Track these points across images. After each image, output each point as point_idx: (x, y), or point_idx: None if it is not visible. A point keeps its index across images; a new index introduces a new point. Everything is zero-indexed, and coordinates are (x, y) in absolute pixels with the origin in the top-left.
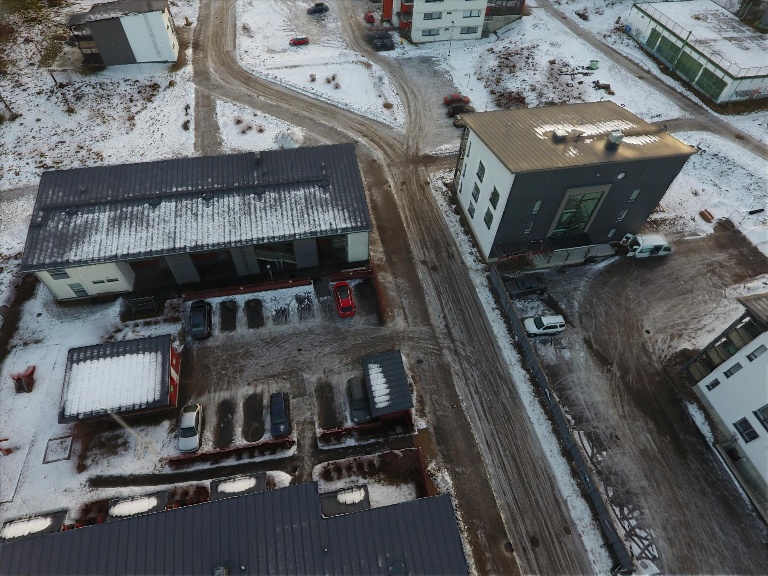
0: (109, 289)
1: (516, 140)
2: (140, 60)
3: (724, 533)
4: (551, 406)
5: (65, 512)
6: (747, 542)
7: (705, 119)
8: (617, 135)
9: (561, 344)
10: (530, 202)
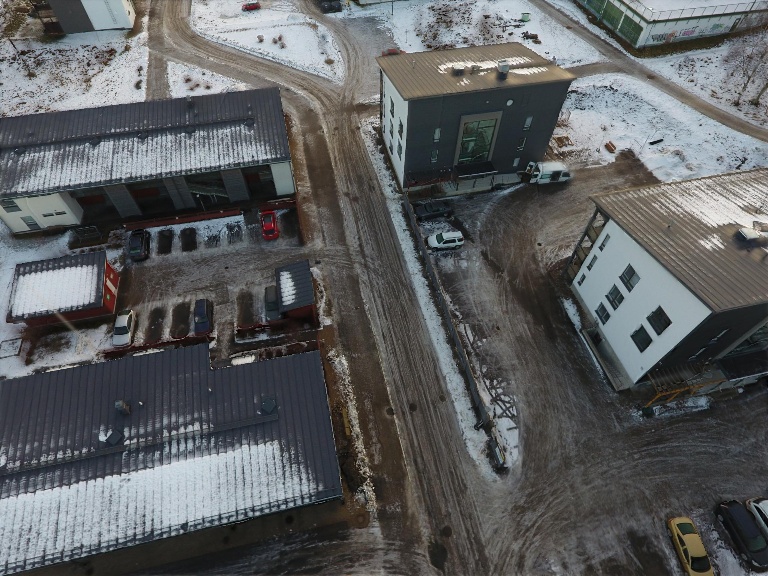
0: (59, 222)
1: (418, 75)
2: (98, 28)
3: (576, 396)
4: (441, 304)
5: (4, 377)
6: (594, 402)
7: (622, 62)
8: (502, 65)
9: (460, 256)
10: (429, 130)
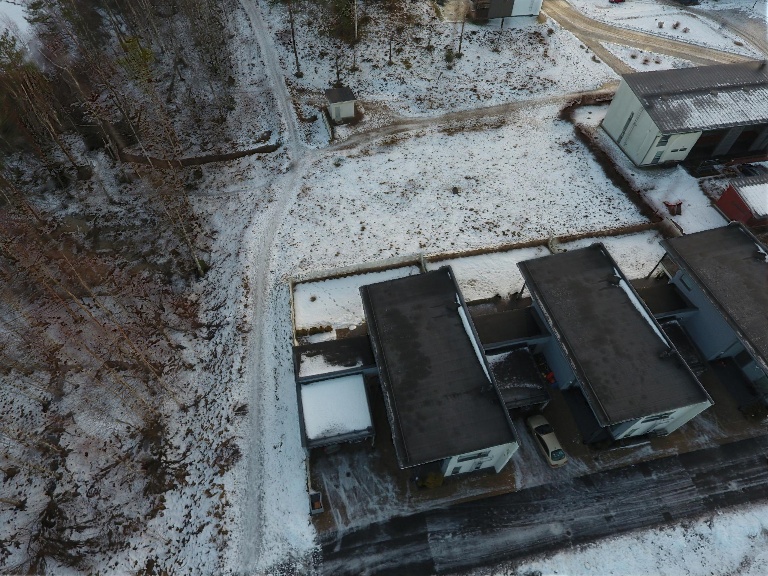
0: (672, 158)
1: None
2: (514, 14)
3: None
4: None
5: None
6: None
7: None
8: None
9: None
10: None
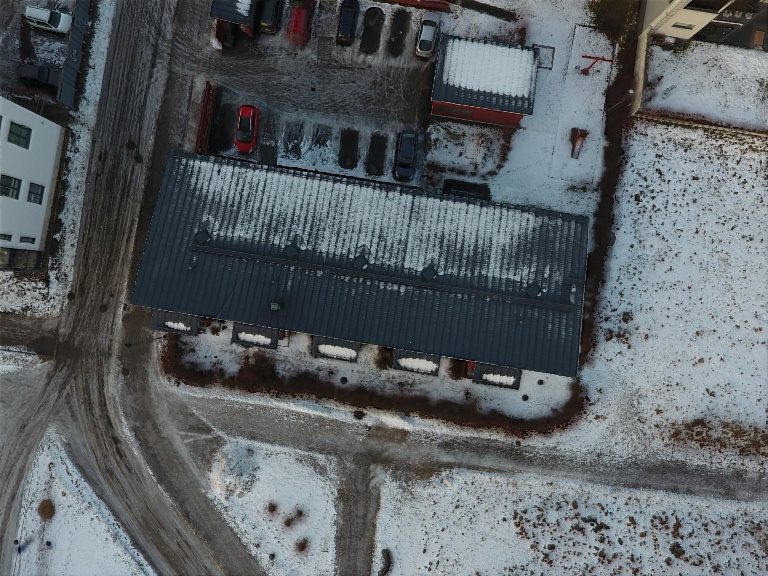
0: None
1: None
2: None
3: None
4: None
5: None
6: None
7: None
8: None
9: (49, 2)
10: None
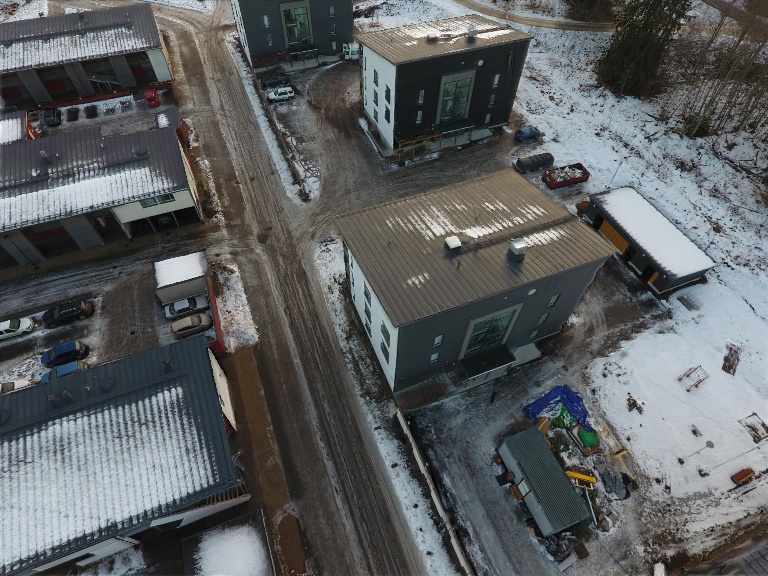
0: None
1: None
2: None
3: (359, 163)
4: None
5: None
6: (370, 164)
7: None
8: None
9: (292, 104)
10: (259, 17)
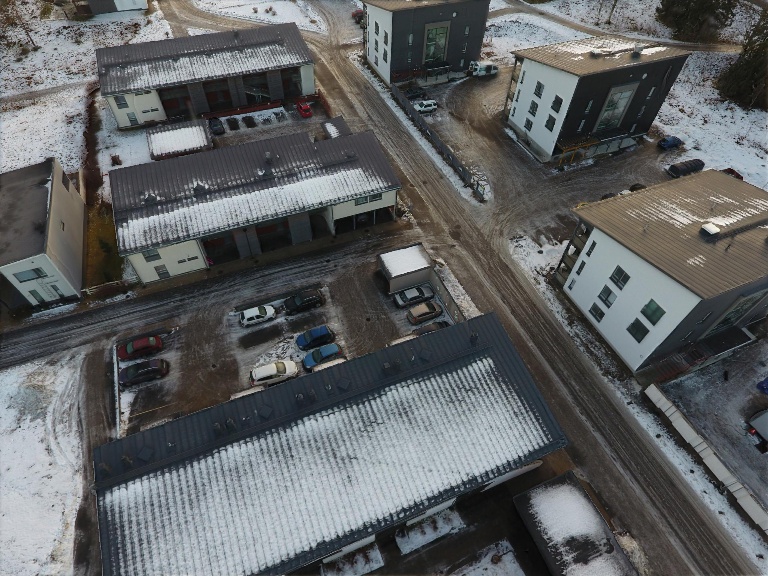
0: (152, 119)
1: (393, 2)
2: (120, 9)
3: (520, 168)
4: None
5: None
6: (530, 169)
7: (522, 7)
8: None
9: (436, 115)
10: (406, 35)
